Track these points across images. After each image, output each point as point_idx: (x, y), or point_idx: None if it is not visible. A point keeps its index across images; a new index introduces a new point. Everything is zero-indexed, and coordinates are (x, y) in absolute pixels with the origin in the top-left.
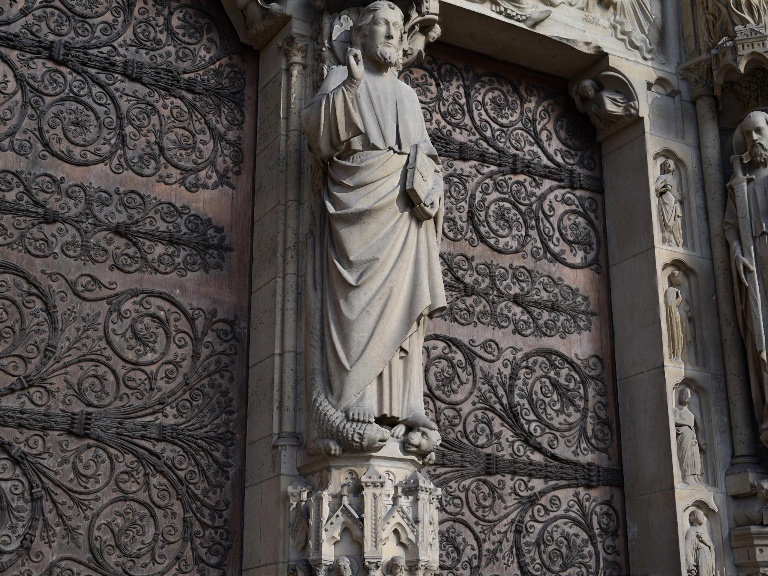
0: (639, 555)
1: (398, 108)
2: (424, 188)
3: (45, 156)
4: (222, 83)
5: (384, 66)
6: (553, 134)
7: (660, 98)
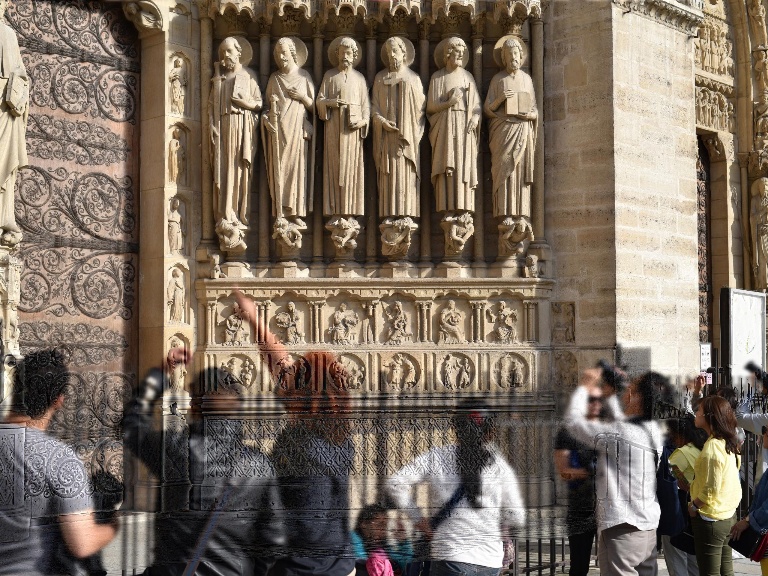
0: (144, 292)
1: (3, 48)
2: (17, 99)
3: None
4: None
5: None
6: (110, 34)
7: (178, 17)
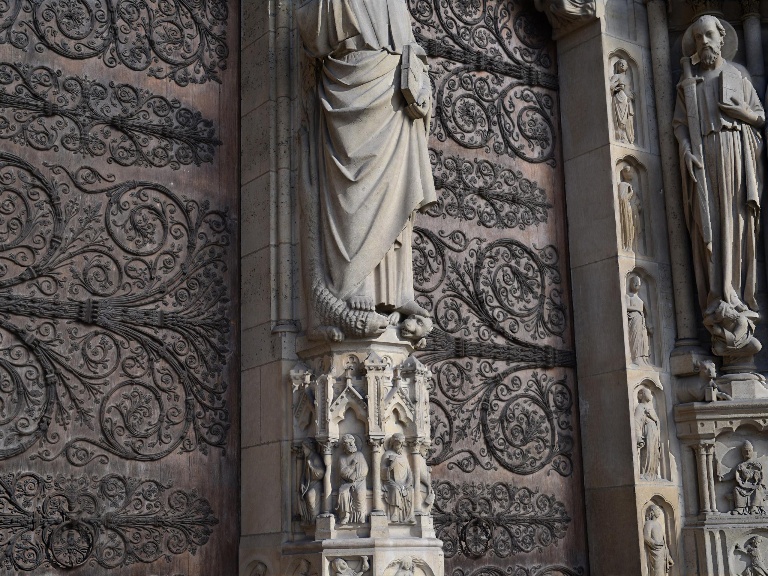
0: (591, 430)
1: (389, 9)
2: (416, 88)
3: (41, 49)
4: None
5: None
6: (513, 32)
7: None
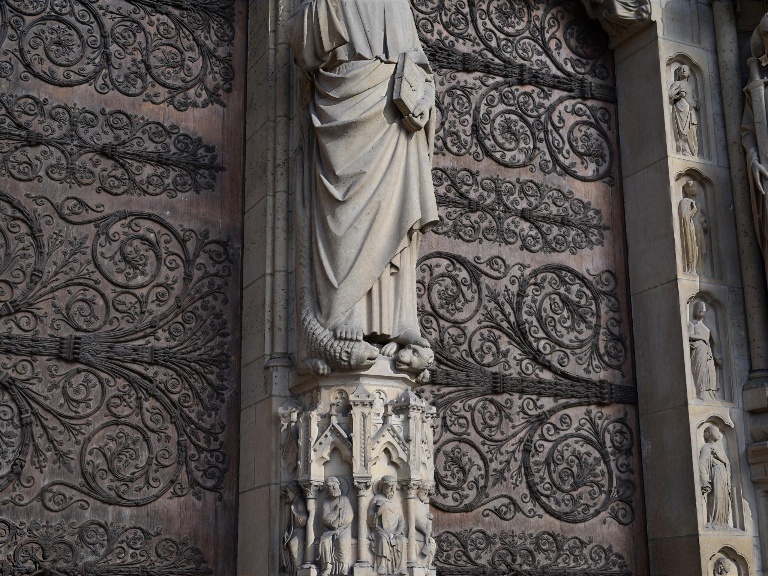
0: (653, 473)
1: (386, 16)
2: (413, 98)
3: (27, 77)
4: None
5: None
6: (563, 42)
7: (675, 1)
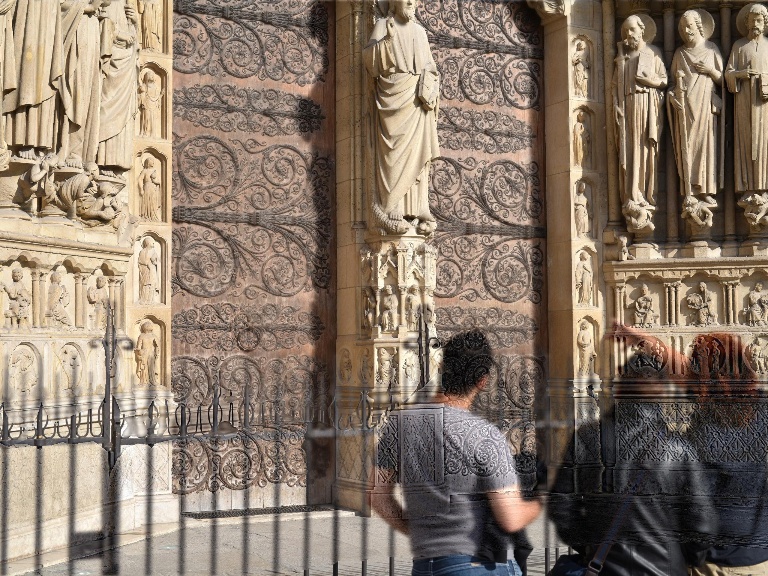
0: (553, 276)
1: (415, 46)
2: (428, 93)
3: (225, 75)
4: (315, 18)
5: (407, 19)
6: (513, 24)
7: None
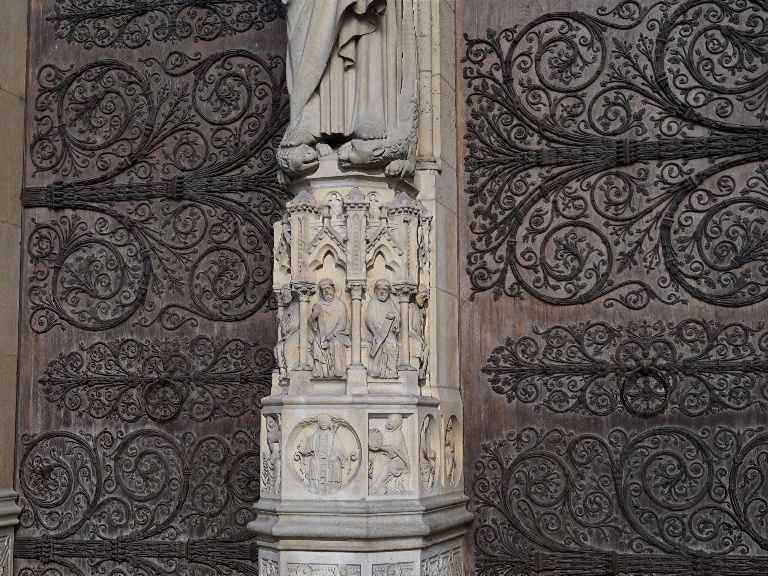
0: None
1: None
2: None
3: None
4: None
5: None
6: None
7: None
